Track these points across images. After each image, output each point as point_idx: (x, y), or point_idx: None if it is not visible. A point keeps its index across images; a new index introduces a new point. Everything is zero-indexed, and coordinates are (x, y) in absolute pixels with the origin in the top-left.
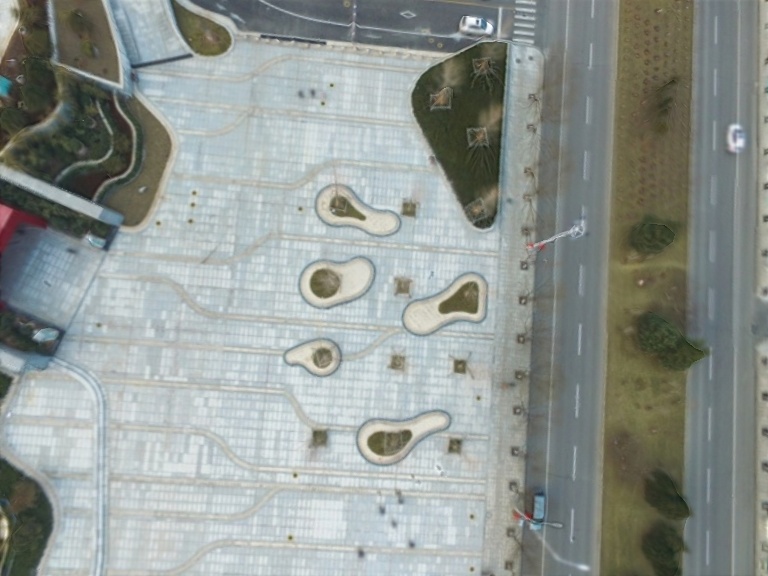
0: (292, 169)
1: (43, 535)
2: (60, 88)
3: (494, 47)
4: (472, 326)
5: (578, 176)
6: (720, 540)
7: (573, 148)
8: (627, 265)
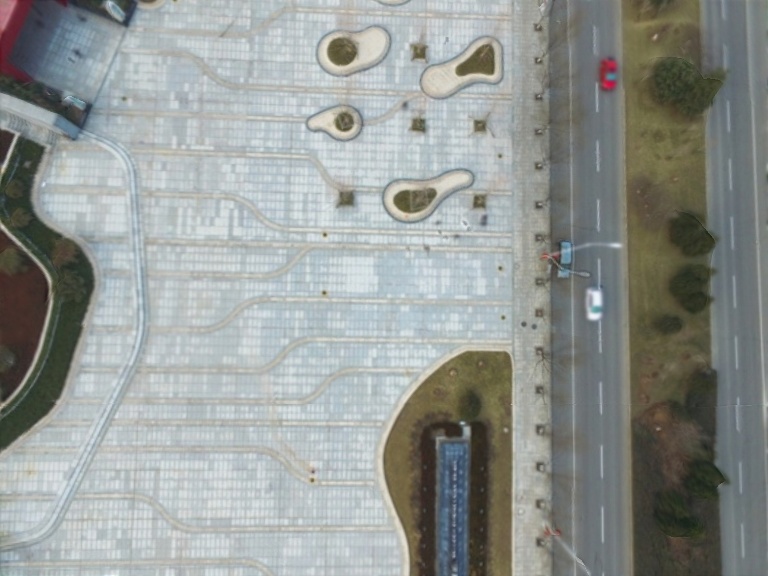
0: None
1: (85, 290)
2: None
3: None
4: (490, 88)
5: None
6: (746, 284)
7: None
8: (640, 22)
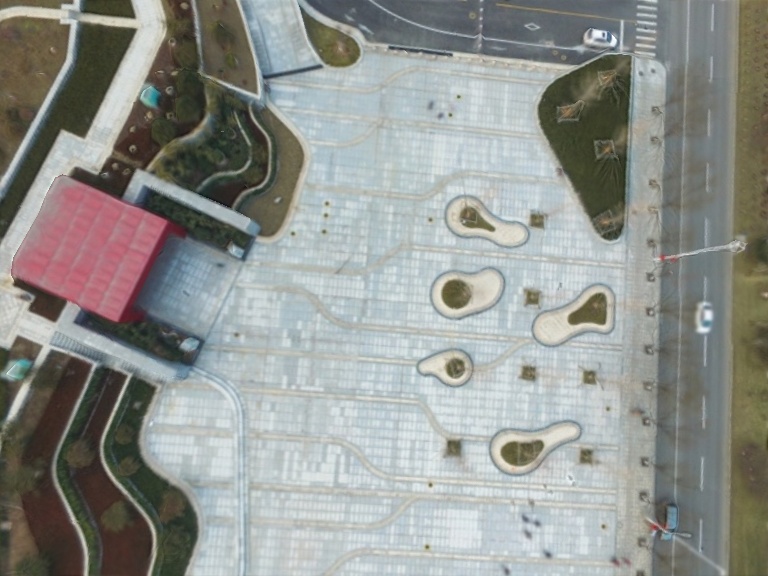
0: (421, 180)
1: (190, 544)
2: (208, 100)
3: (619, 60)
4: (600, 337)
5: (701, 188)
6: None
7: (695, 160)
8: (752, 277)
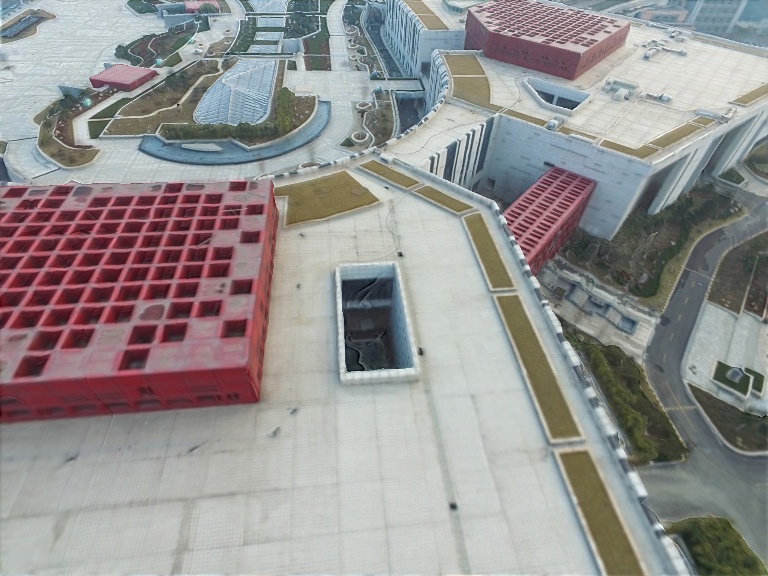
0: None
1: None
2: None
3: None
4: None
5: None
6: None
7: None
8: None
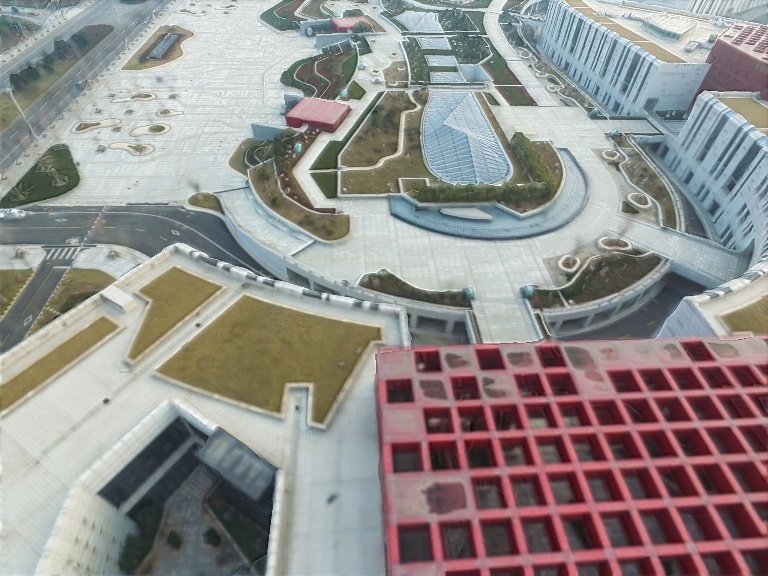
0: None
1: None
2: None
3: (6, 205)
4: None
5: None
6: None
7: None
8: None
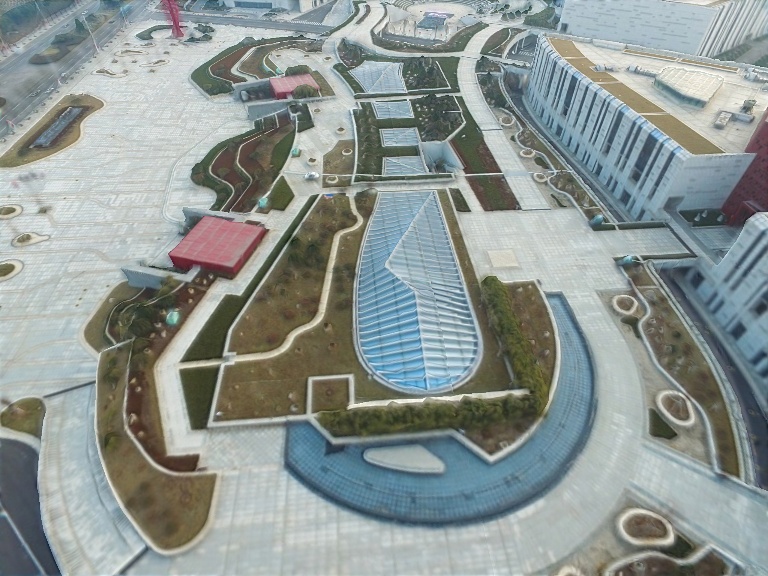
0: None
1: None
2: None
3: None
4: None
5: None
6: None
7: None
8: None
